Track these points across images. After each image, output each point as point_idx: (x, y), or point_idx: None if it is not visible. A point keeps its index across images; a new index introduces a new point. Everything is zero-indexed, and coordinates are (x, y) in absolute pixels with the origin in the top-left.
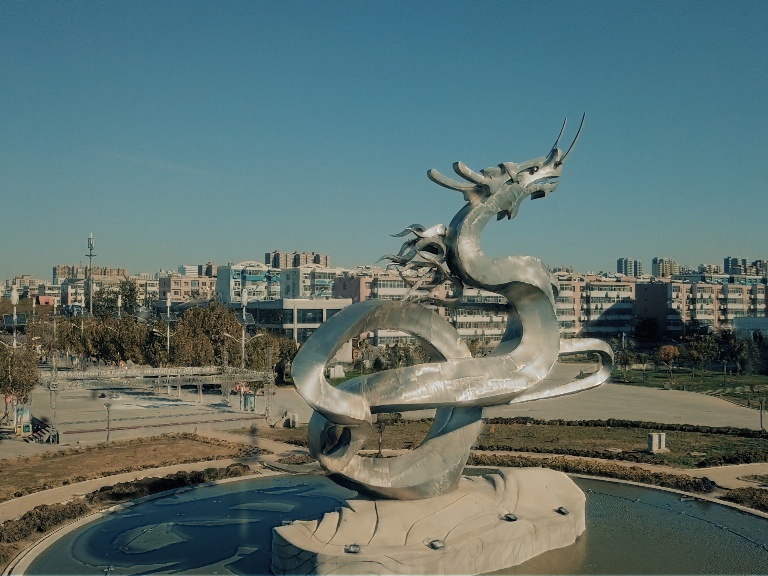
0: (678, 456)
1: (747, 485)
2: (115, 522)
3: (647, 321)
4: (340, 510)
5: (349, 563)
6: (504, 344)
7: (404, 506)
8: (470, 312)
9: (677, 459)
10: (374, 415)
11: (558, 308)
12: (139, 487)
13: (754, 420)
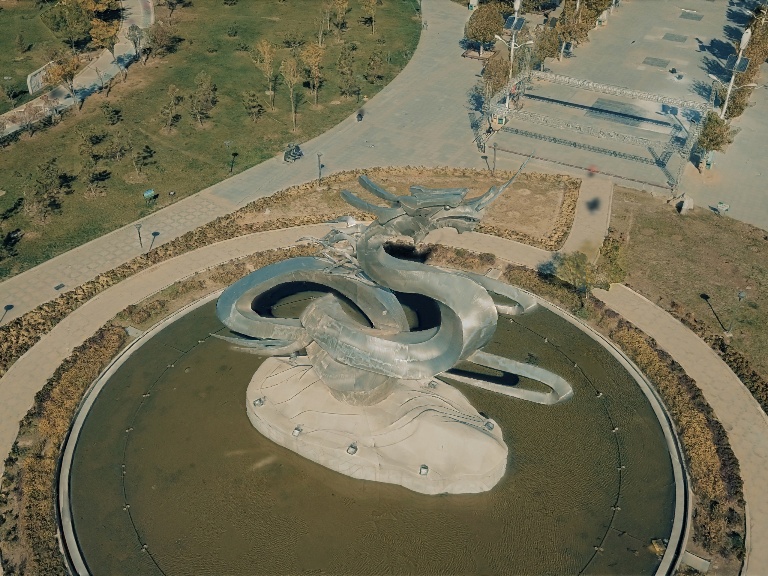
0: None
1: None
2: None
3: None
4: None
5: None
6: (433, 330)
7: (322, 395)
8: None
9: None
10: None
11: None
12: None
13: None
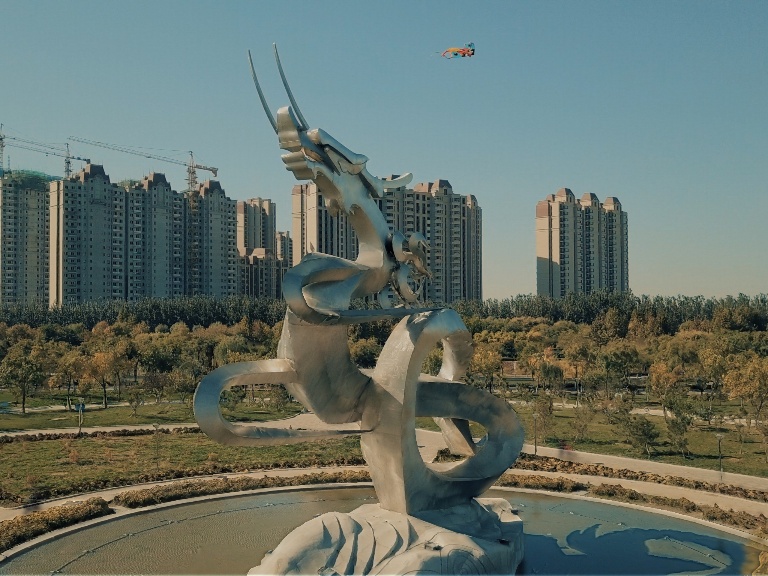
0: None
1: None
2: None
3: None
4: None
5: None
6: None
7: None
8: None
9: None
10: None
11: None
12: None
13: None
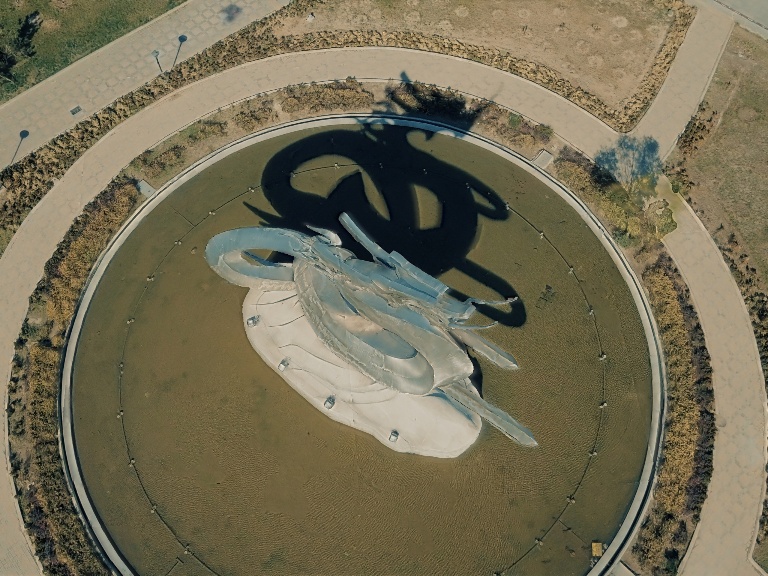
0: None
1: None
2: (353, 135)
3: None
4: None
5: None
6: None
7: (312, 331)
8: None
9: None
10: None
11: None
12: (427, 106)
13: None
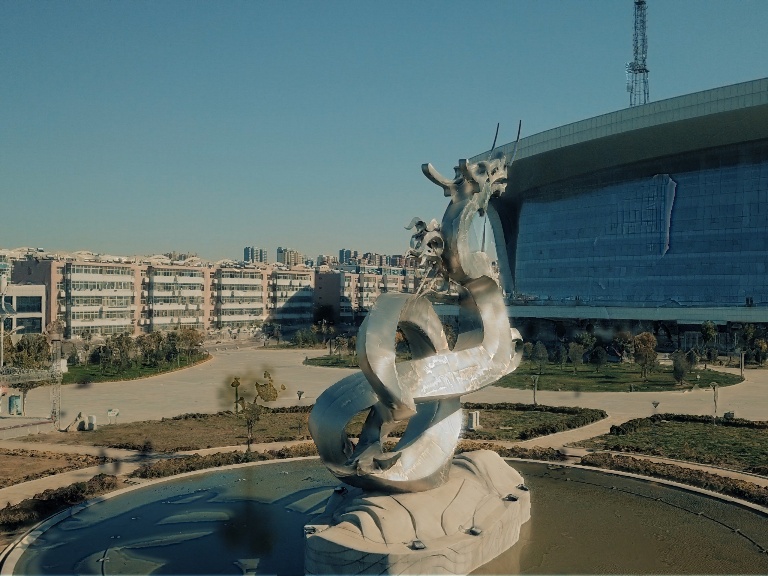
0: (494, 431)
1: (579, 451)
2: (45, 556)
3: (323, 308)
4: (366, 509)
5: (420, 560)
6: (466, 335)
7: (422, 498)
8: (166, 300)
9: (497, 434)
10: (157, 411)
11: (248, 296)
12: (26, 512)
13: (506, 396)
